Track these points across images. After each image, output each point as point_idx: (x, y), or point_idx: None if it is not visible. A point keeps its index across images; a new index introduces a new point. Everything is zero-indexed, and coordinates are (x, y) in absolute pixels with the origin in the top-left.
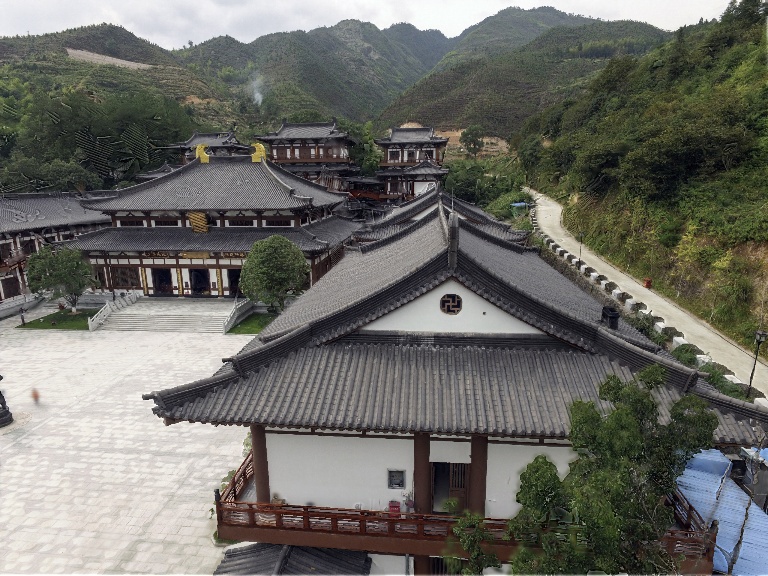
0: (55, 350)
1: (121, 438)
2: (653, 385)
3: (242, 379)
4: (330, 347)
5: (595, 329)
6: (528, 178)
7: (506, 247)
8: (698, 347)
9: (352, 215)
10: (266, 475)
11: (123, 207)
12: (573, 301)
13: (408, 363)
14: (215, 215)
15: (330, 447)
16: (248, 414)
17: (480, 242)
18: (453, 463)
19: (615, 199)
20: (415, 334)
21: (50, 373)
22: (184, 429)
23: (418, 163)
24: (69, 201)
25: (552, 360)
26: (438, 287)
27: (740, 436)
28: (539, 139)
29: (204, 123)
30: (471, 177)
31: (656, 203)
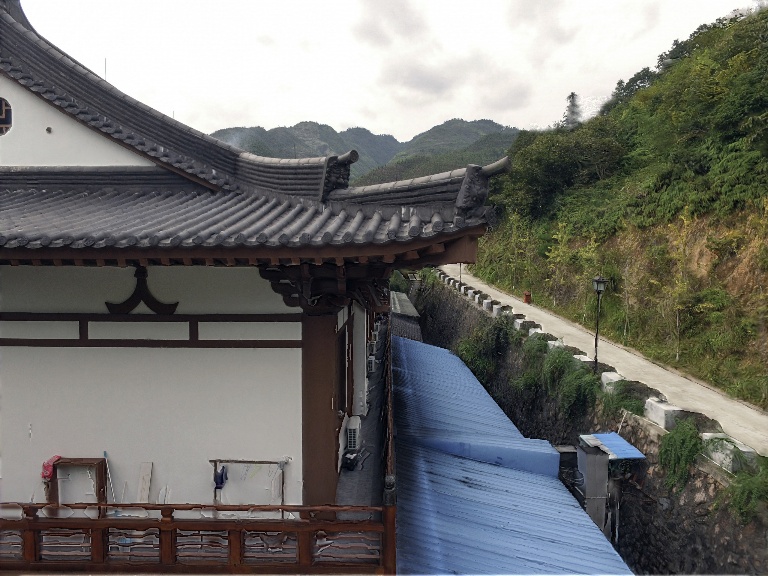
0: None
1: None
2: None
3: None
4: None
5: (235, 153)
6: None
7: None
8: None
9: None
10: None
11: None
12: None
13: None
14: None
15: None
16: None
17: None
18: None
19: (506, 228)
20: None
21: None
22: None
23: None
24: None
25: None
26: None
27: (366, 230)
28: None
29: None
30: None
31: (538, 221)
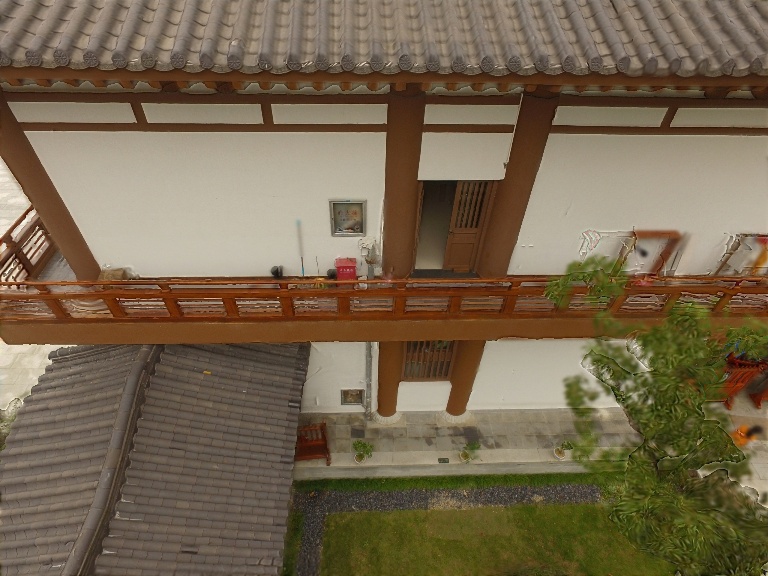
0: None
1: None
2: None
3: None
4: None
5: None
6: None
7: None
8: None
9: None
10: (70, 226)
11: None
12: None
13: None
14: None
15: (194, 158)
16: None
17: None
18: (463, 182)
19: None
20: None
21: None
22: None
23: None
24: None
25: None
26: None
27: None
28: None
29: None
30: None
31: None
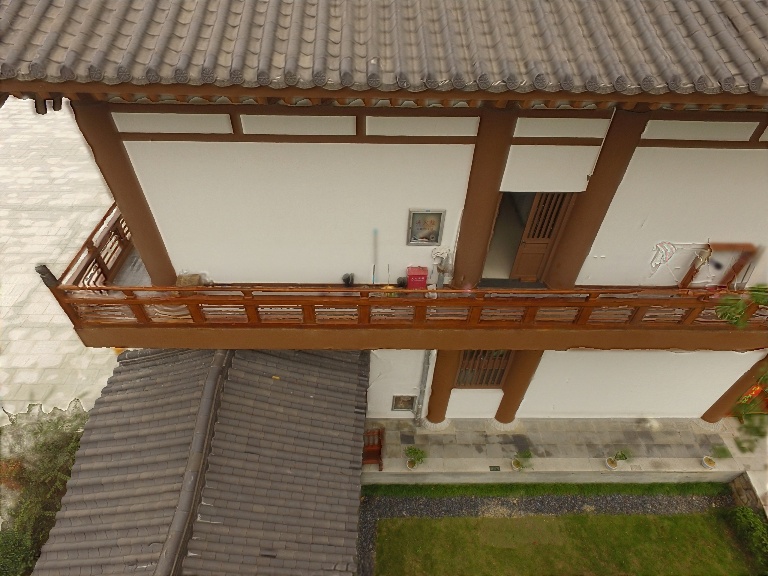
0: None
1: None
2: None
3: None
4: None
5: None
6: None
7: None
8: None
9: None
10: (154, 232)
11: None
12: None
13: None
14: None
15: (283, 168)
16: (7, 55)
17: None
18: (542, 193)
19: None
20: None
21: None
22: (56, 173)
23: None
24: None
25: None
26: None
27: None
28: None
29: None
30: None
31: None
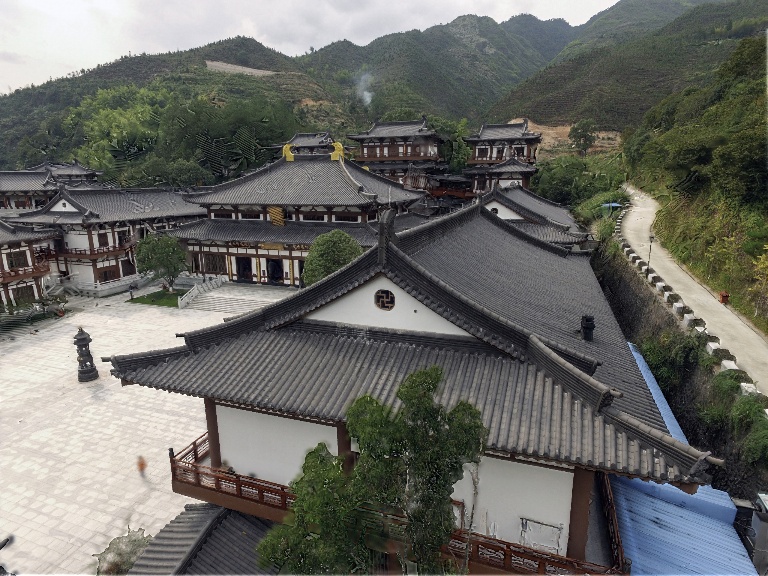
0: (147, 322)
1: (171, 402)
2: (432, 387)
3: (193, 353)
4: (278, 332)
5: (526, 336)
6: (629, 176)
7: (548, 249)
8: (753, 375)
9: (429, 213)
10: (217, 443)
11: (215, 201)
12: (570, 309)
13: (337, 353)
14: (291, 210)
15: (266, 424)
16: (183, 384)
17: (512, 243)
18: None
19: (707, 200)
20: (351, 326)
21: (137, 341)
22: None
23: (504, 160)
24: (175, 195)
25: (477, 364)
26: (372, 282)
27: (635, 466)
28: (649, 133)
29: (315, 124)
30: (568, 175)
31: (750, 206)
